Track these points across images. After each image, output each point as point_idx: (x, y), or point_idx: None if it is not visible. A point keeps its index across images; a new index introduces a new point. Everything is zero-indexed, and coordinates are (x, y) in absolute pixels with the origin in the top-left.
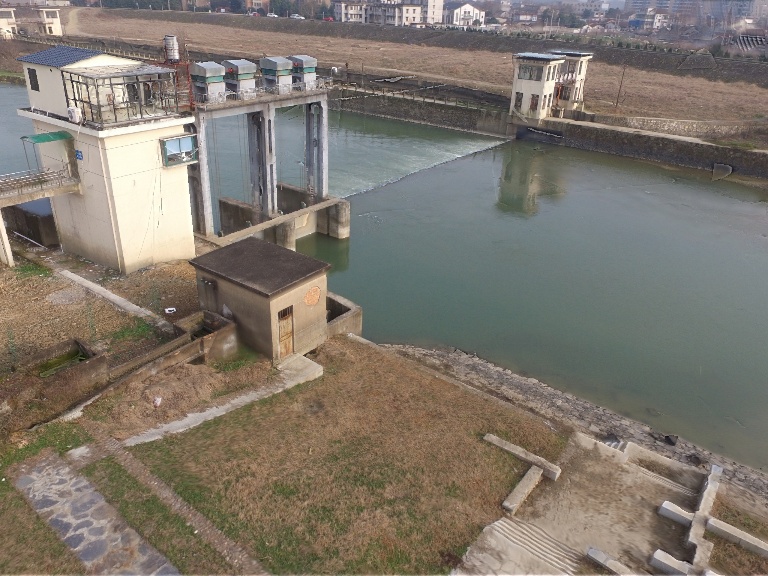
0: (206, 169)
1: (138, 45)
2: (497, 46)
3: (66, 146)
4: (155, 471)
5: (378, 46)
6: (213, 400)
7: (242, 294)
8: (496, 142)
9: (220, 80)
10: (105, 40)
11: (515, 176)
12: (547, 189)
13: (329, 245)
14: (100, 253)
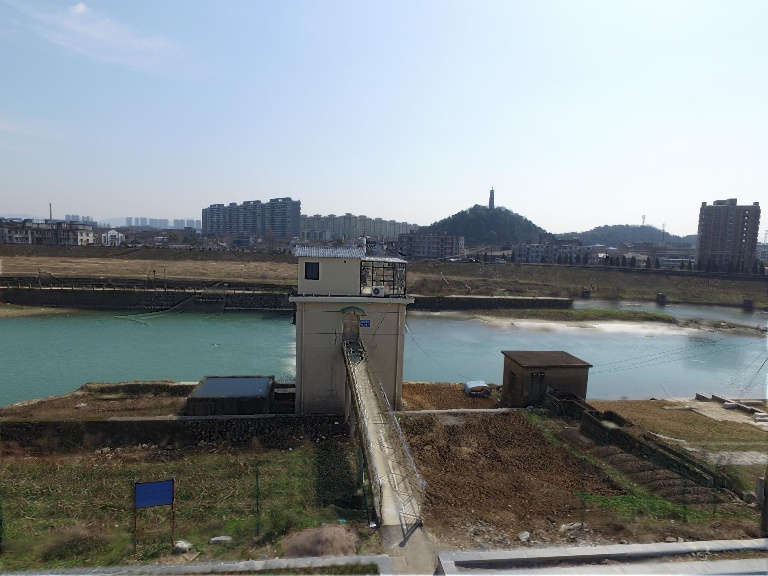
0: None
1: None
2: (196, 257)
3: (344, 320)
4: None
5: (91, 261)
6: None
7: (566, 373)
8: None
9: None
10: None
11: None
12: None
13: None
14: None
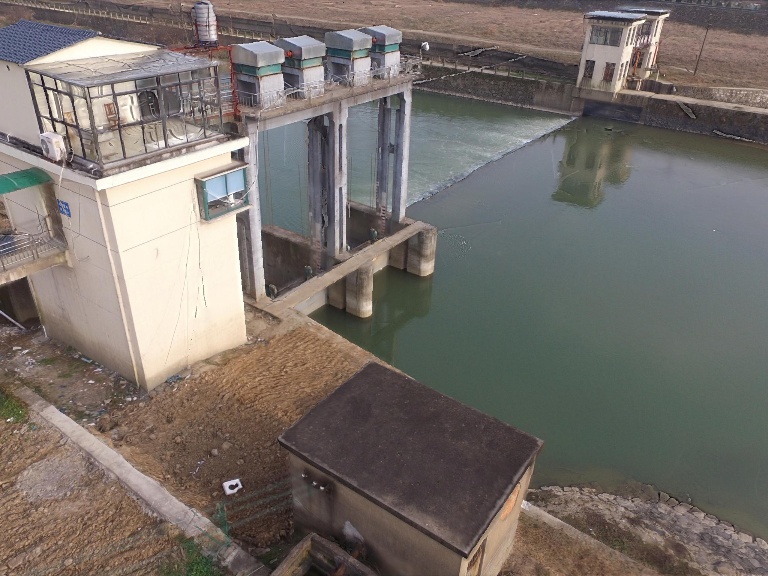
0: (256, 206)
1: (126, 5)
2: (524, 1)
3: (41, 190)
4: None
5: (392, 3)
6: None
7: (392, 522)
8: (559, 120)
9: (276, 70)
10: (89, 0)
11: (580, 160)
12: (612, 173)
13: (406, 283)
14: (104, 352)
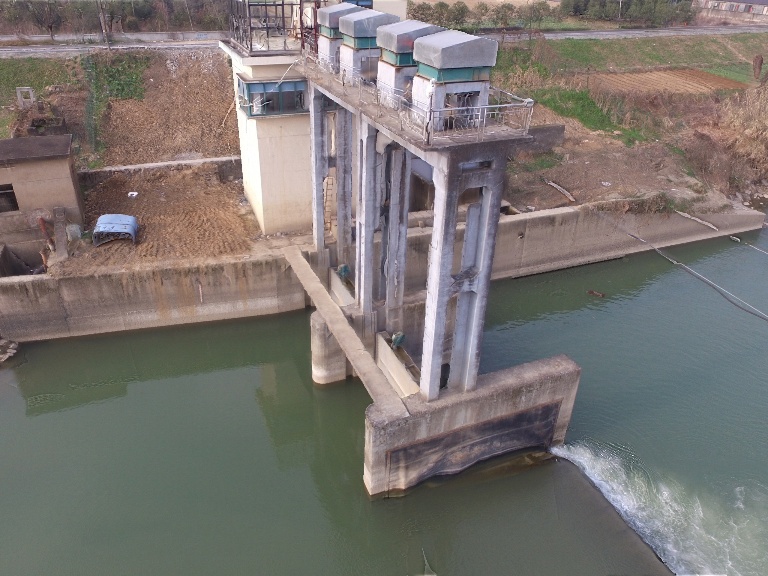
0: None
1: None
2: None
3: None
4: None
5: None
6: None
7: None
8: None
9: None
10: None
11: None
12: None
13: None
14: None
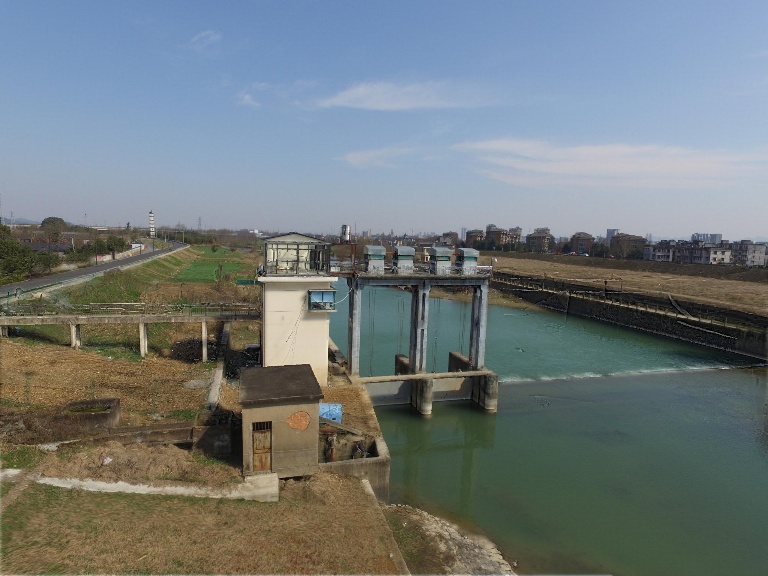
0: (358, 322)
1: None
2: None
3: None
4: (11, 506)
5: (670, 277)
6: (155, 480)
7: None
8: (757, 364)
9: (381, 258)
10: None
11: None
12: None
13: (478, 413)
14: None
